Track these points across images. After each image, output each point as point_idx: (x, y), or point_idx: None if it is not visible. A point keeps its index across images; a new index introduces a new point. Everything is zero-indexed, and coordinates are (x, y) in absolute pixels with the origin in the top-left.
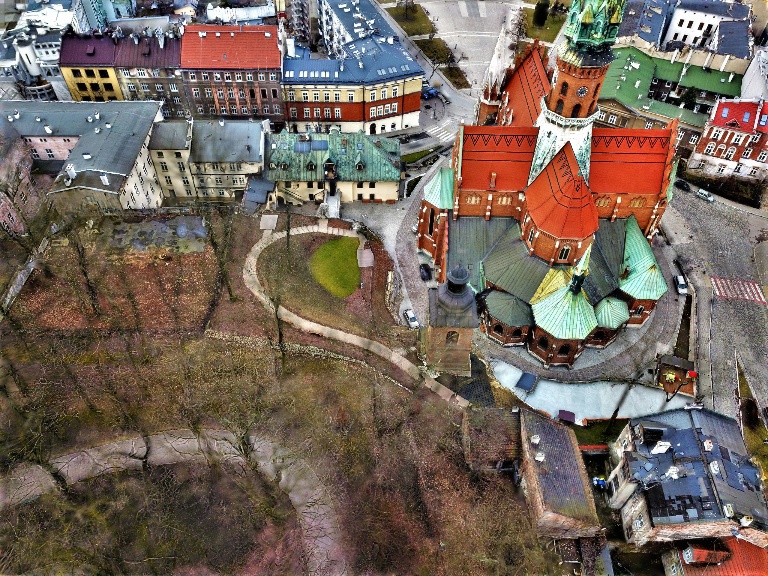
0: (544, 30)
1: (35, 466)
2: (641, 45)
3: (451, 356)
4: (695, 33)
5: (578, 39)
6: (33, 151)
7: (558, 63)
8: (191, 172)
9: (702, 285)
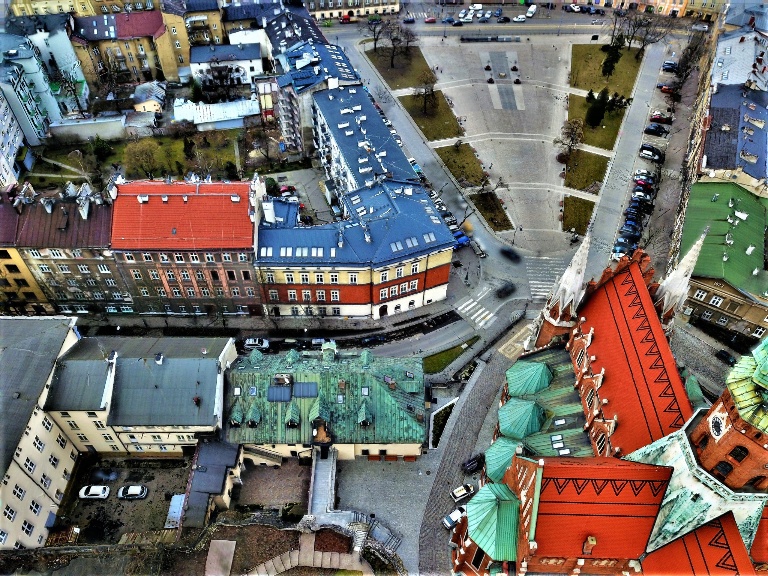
0: (599, 130)
1: None
2: (745, 181)
3: None
4: None
5: None
6: None
7: (728, 409)
8: (114, 430)
9: None
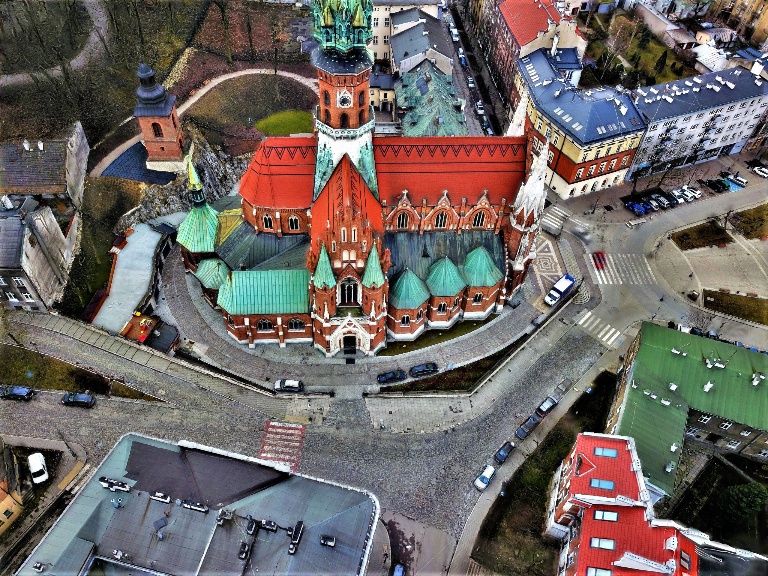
0: None
1: None
2: None
3: None
4: None
5: None
6: None
7: None
8: None
9: (288, 410)
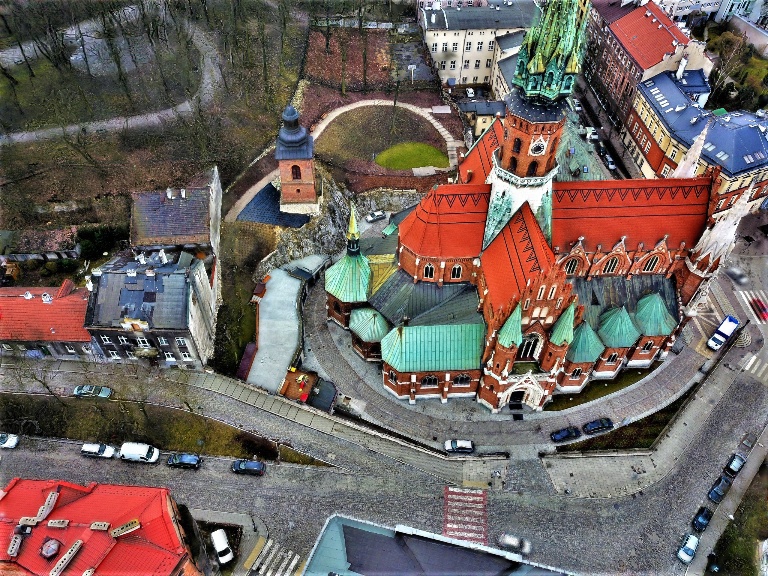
0: None
1: (175, 7)
2: None
3: None
4: None
5: None
6: (481, 4)
7: None
8: None
9: (465, 473)
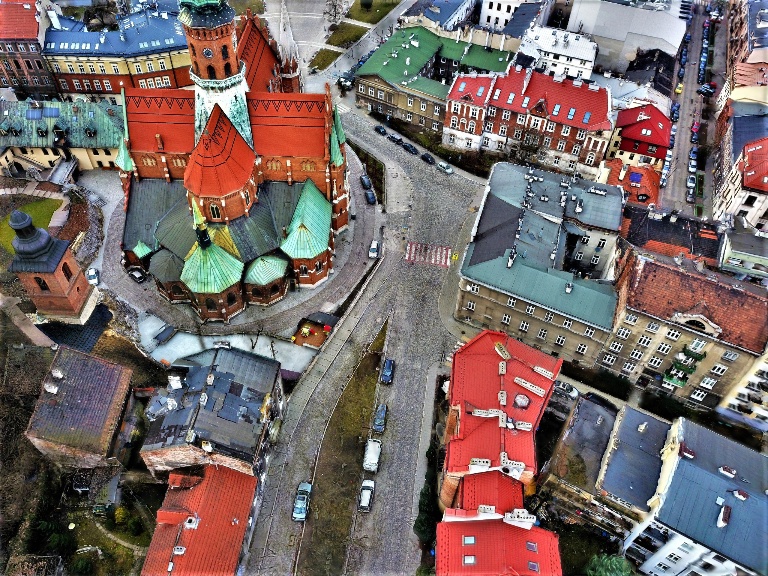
0: (372, 12)
1: None
2: (428, 24)
3: (54, 303)
4: (505, 16)
5: (182, 0)
6: None
7: None
8: None
9: (395, 250)
